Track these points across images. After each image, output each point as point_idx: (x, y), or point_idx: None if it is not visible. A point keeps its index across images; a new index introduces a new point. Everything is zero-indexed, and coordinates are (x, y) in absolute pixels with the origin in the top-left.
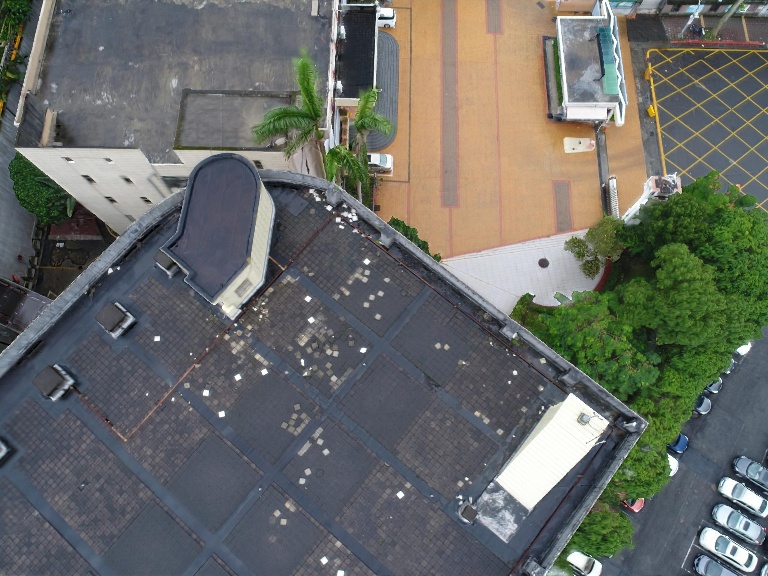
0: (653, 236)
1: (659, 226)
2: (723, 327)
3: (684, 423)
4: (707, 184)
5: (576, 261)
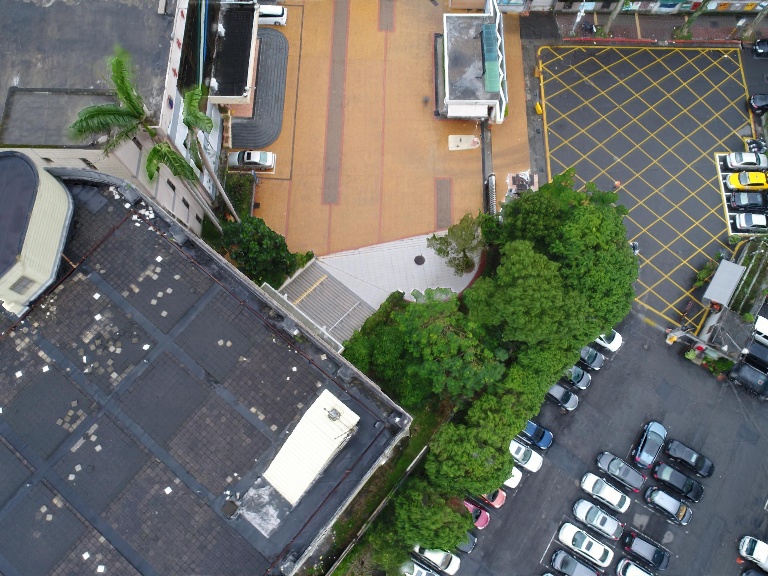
0: (506, 233)
1: (509, 223)
2: (563, 323)
3: (552, 419)
4: (562, 181)
5: None
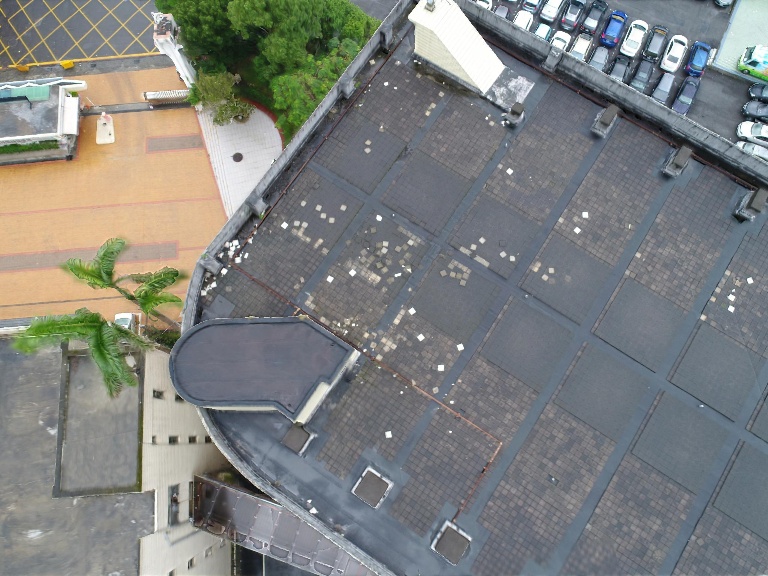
0: (217, 38)
1: (208, 29)
2: None
3: None
4: None
5: (234, 129)
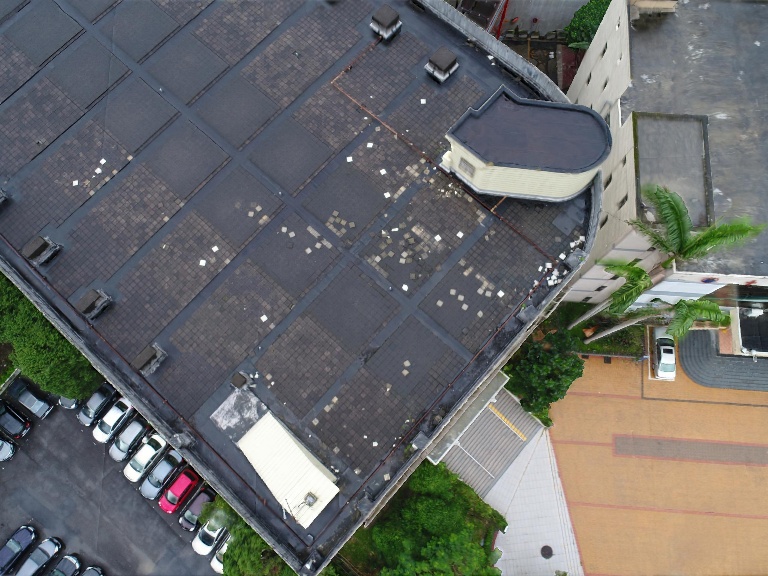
0: None
1: None
2: None
3: None
4: None
5: None
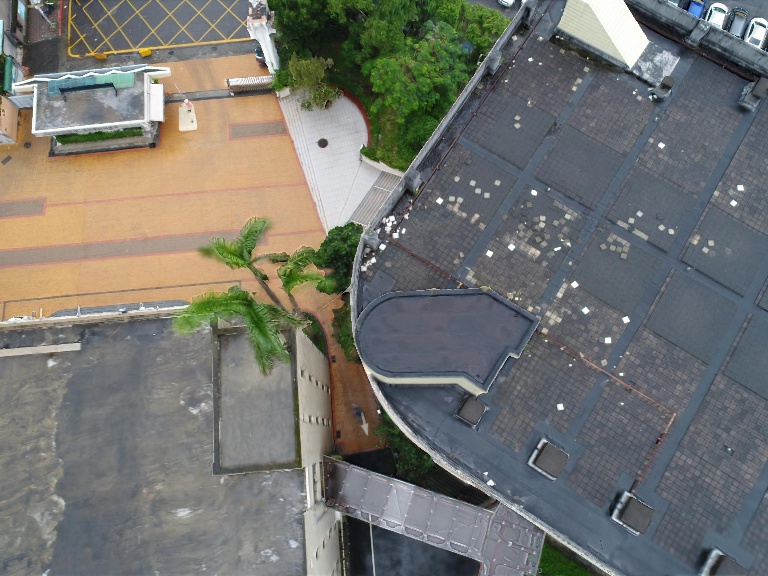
0: (313, 21)
1: (306, 12)
2: None
3: None
4: None
5: (318, 115)
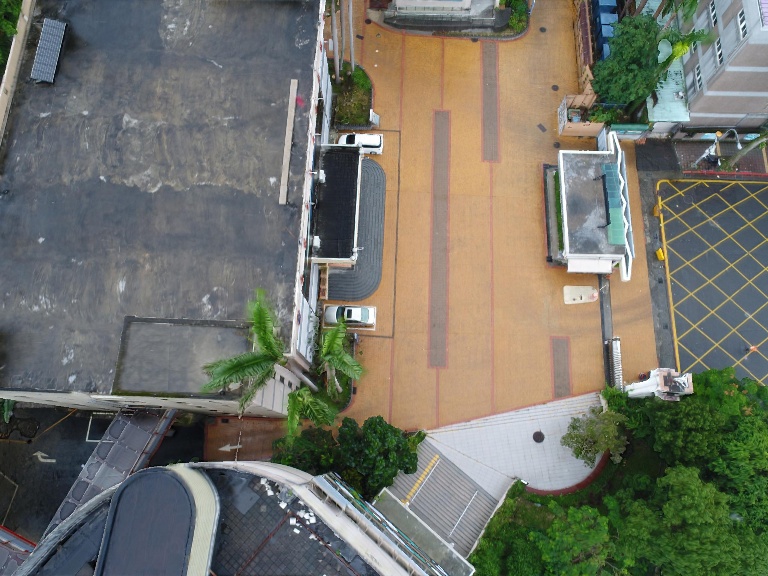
0: (660, 446)
1: (667, 440)
2: (737, 571)
3: None
4: (722, 385)
5: None
